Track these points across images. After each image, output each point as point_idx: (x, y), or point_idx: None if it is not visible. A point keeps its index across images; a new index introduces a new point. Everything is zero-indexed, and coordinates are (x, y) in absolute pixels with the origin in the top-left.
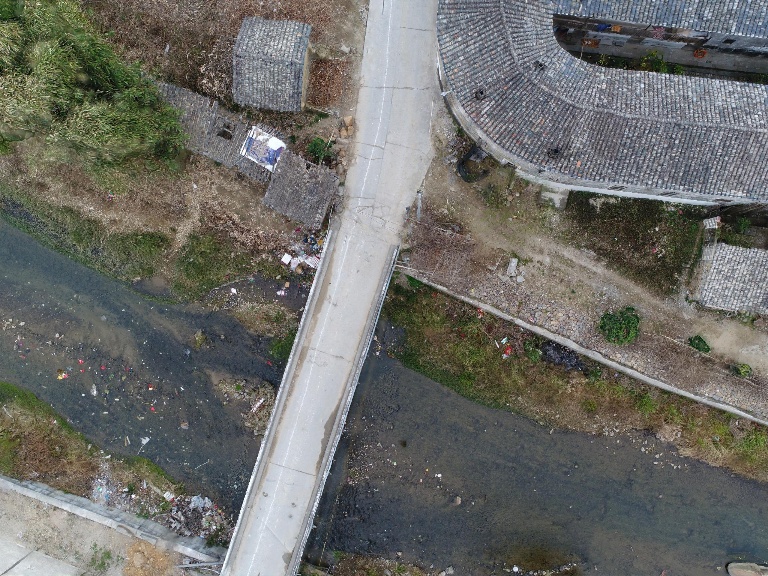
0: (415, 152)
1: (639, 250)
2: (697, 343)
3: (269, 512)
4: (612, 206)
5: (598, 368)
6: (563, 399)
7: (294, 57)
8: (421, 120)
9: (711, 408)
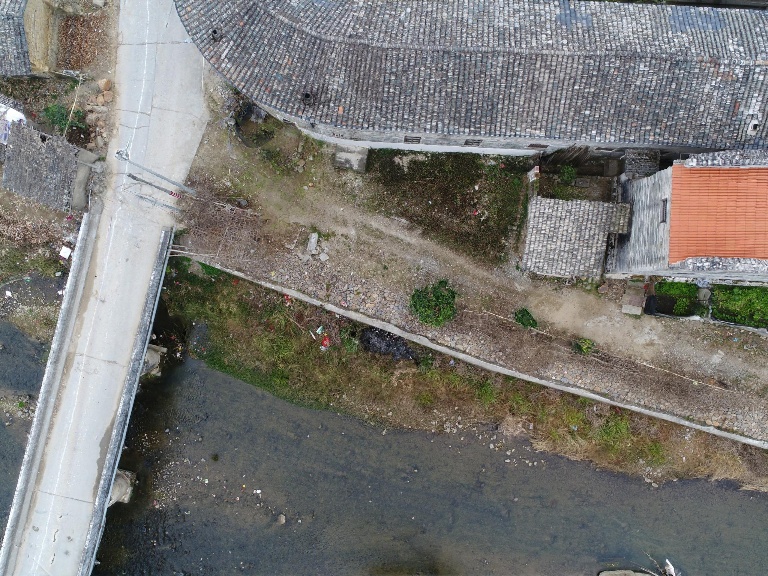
0: (186, 116)
1: (458, 214)
2: (520, 317)
3: (41, 549)
4: (421, 164)
5: (430, 355)
6: (394, 394)
7: (10, 9)
8: (191, 78)
9: (564, 393)
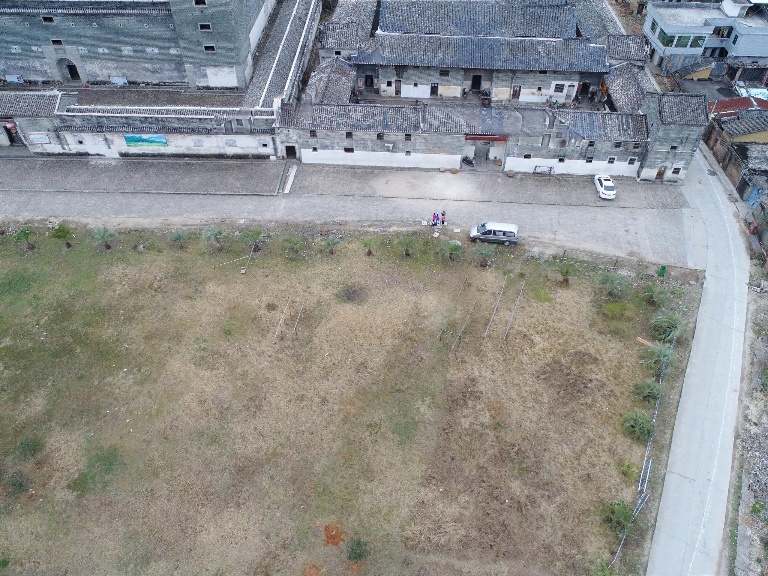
0: None
1: None
2: None
3: None
4: None
5: None
6: None
7: None
8: None
9: None
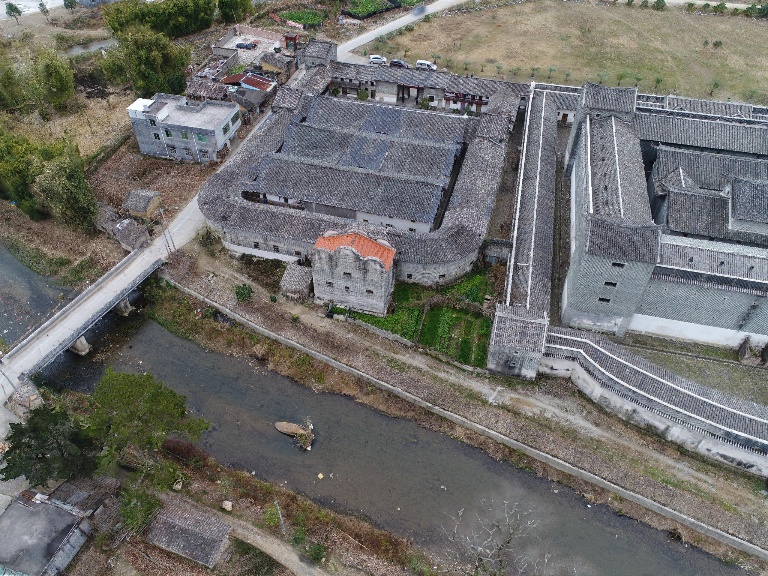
0: (187, 236)
1: (268, 277)
2: None
3: (45, 342)
4: (261, 261)
5: (239, 325)
6: (218, 337)
7: None
8: (195, 228)
9: (288, 347)
